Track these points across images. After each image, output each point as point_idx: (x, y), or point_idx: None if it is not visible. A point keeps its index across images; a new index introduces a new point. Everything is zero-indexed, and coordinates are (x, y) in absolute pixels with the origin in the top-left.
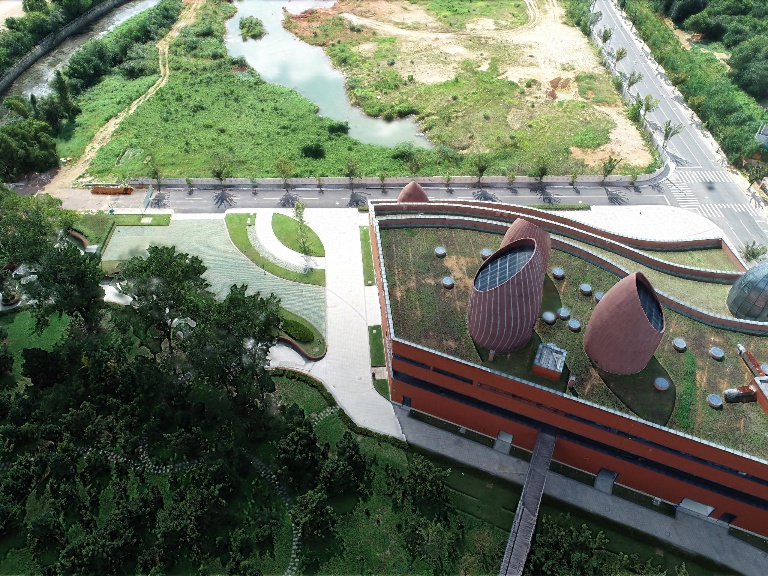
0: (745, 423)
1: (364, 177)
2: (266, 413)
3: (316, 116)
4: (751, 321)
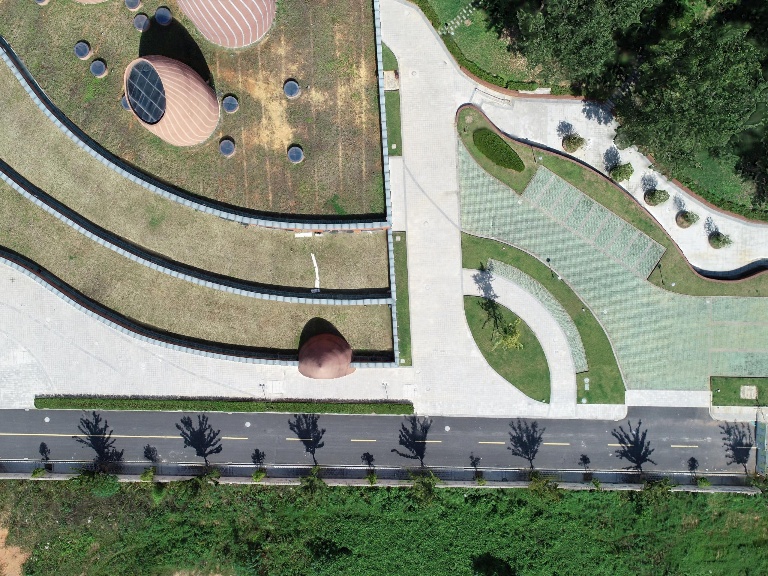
0: None
1: None
2: None
3: None
4: None
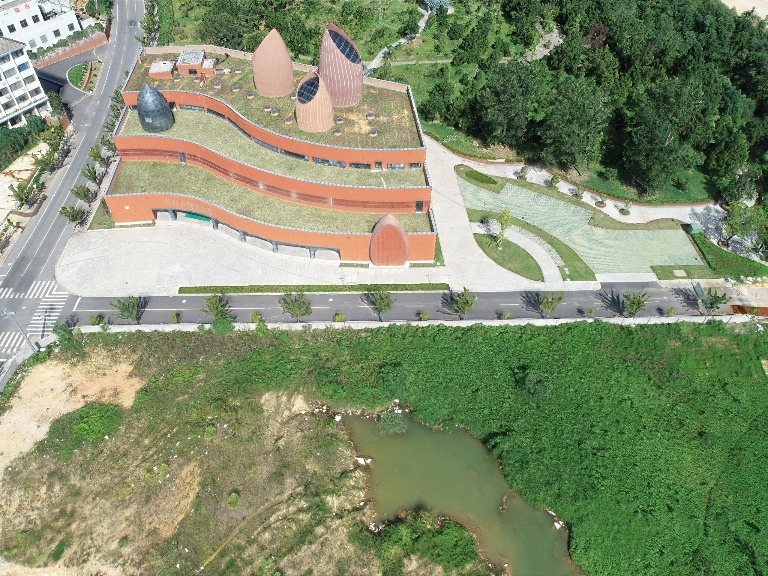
0: (229, 66)
1: (448, 321)
2: (480, 114)
3: (560, 491)
4: (183, 91)
